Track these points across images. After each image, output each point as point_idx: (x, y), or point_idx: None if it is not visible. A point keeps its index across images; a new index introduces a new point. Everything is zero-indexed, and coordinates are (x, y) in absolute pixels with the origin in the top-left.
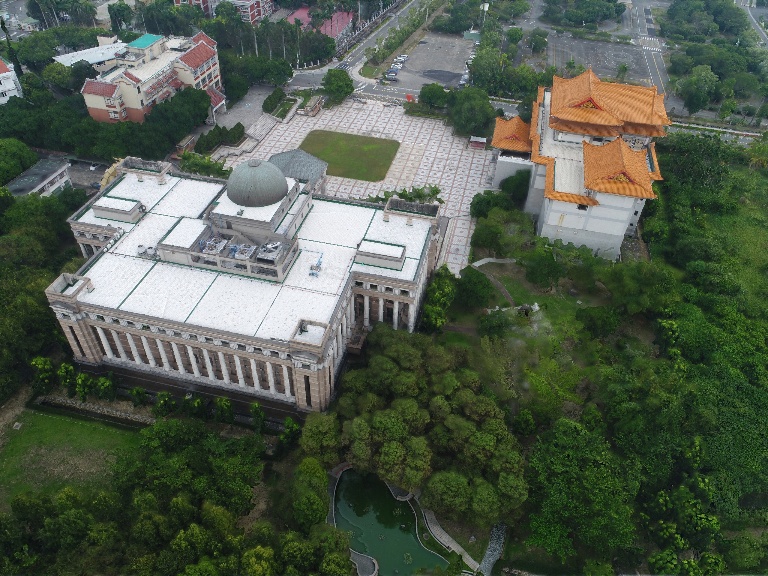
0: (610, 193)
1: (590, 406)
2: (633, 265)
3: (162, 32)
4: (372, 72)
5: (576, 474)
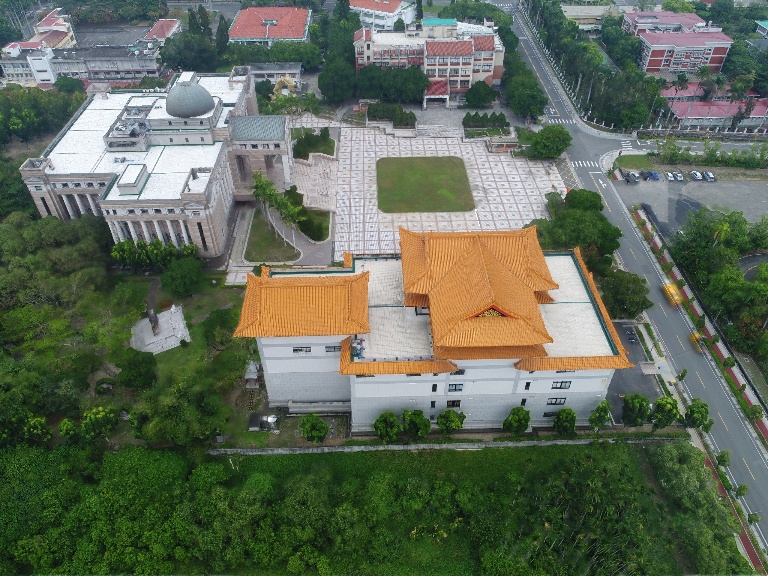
0: None
1: (1, 353)
2: (191, 373)
3: None
4: (635, 163)
5: None
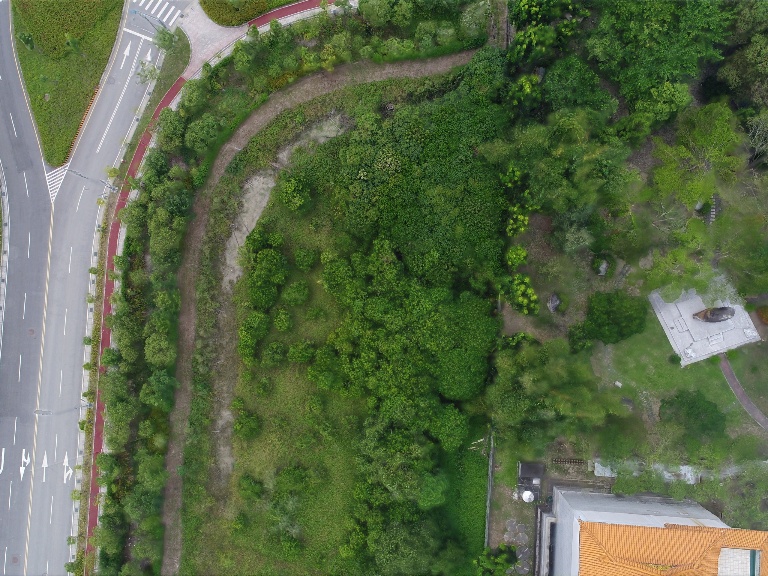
0: (668, 529)
1: None
2: (575, 414)
3: None
4: None
5: (685, 4)
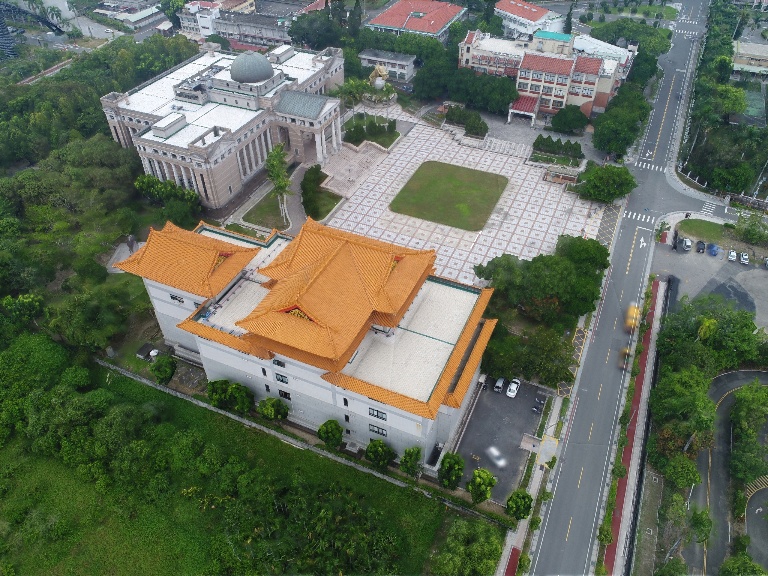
0: None
1: None
2: (102, 291)
3: (733, 85)
4: (701, 231)
5: None
